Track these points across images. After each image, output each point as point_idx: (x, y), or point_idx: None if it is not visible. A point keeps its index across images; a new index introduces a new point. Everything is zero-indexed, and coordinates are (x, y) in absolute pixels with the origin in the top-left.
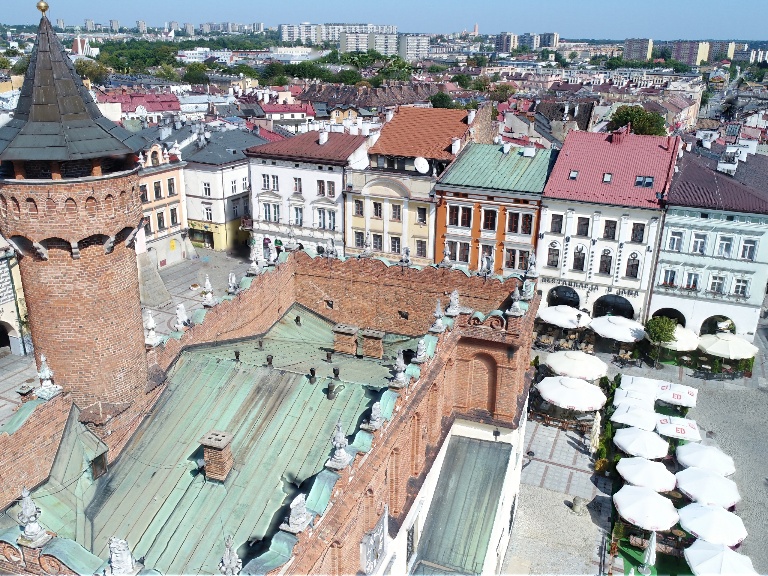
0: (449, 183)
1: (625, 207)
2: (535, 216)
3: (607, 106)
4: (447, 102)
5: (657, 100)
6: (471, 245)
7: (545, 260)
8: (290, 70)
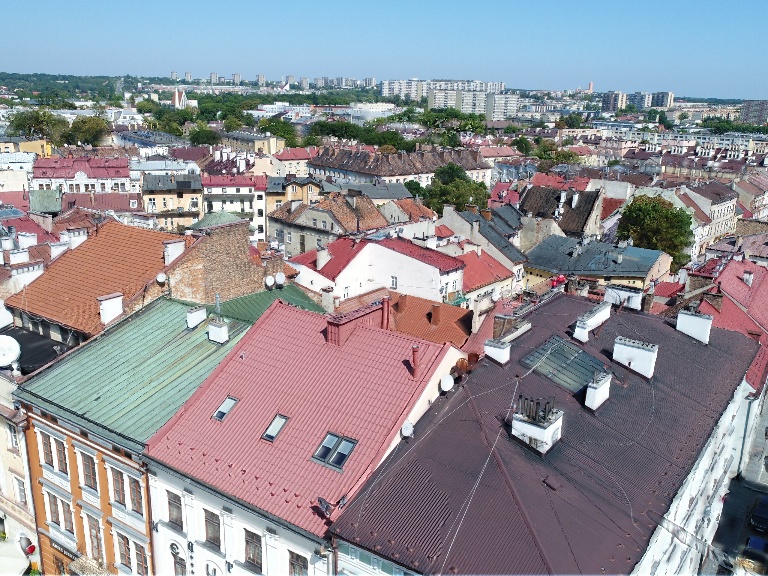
0: (32, 391)
1: (261, 516)
2: (143, 485)
3: (654, 187)
4: (458, 175)
5: (732, 179)
6: (73, 509)
7: (168, 572)
8: (325, 130)
